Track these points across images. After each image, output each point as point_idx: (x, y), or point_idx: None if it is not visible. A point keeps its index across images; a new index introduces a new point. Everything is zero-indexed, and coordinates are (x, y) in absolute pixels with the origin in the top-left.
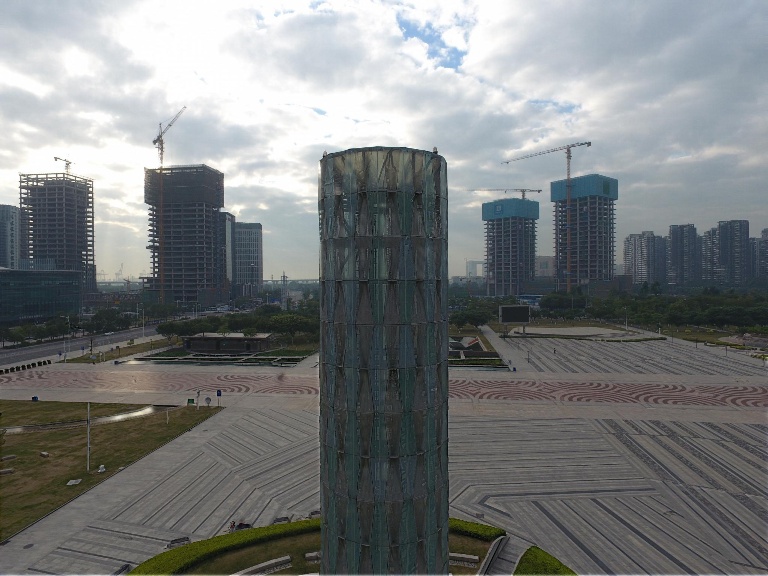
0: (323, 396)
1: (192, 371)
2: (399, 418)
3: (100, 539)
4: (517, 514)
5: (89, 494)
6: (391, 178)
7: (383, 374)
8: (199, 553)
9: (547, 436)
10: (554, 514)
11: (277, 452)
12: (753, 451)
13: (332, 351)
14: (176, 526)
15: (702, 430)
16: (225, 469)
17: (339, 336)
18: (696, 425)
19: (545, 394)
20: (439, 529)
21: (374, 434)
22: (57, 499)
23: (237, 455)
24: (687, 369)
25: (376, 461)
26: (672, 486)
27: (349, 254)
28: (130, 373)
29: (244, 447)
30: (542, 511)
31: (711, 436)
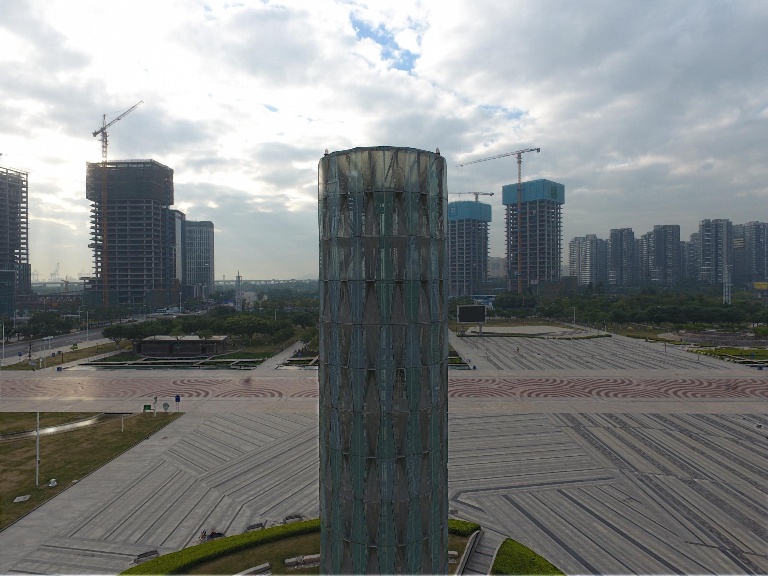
0: (325, 398)
1: (145, 376)
2: (406, 417)
3: (57, 558)
4: (489, 508)
5: (40, 510)
6: (397, 178)
7: (390, 374)
8: (172, 566)
9: (511, 431)
10: (524, 506)
11: (244, 457)
12: (696, 439)
13: (335, 352)
14: (142, 539)
15: (650, 421)
16: (190, 477)
17: (344, 336)
18: (645, 416)
19: (505, 391)
20: (442, 526)
21: (381, 434)
22: (4, 518)
23: (202, 462)
24: (632, 364)
25: (383, 461)
26: (629, 474)
27: (355, 254)
28: (76, 380)
29: (208, 453)
30: (512, 504)
31: (659, 426)
